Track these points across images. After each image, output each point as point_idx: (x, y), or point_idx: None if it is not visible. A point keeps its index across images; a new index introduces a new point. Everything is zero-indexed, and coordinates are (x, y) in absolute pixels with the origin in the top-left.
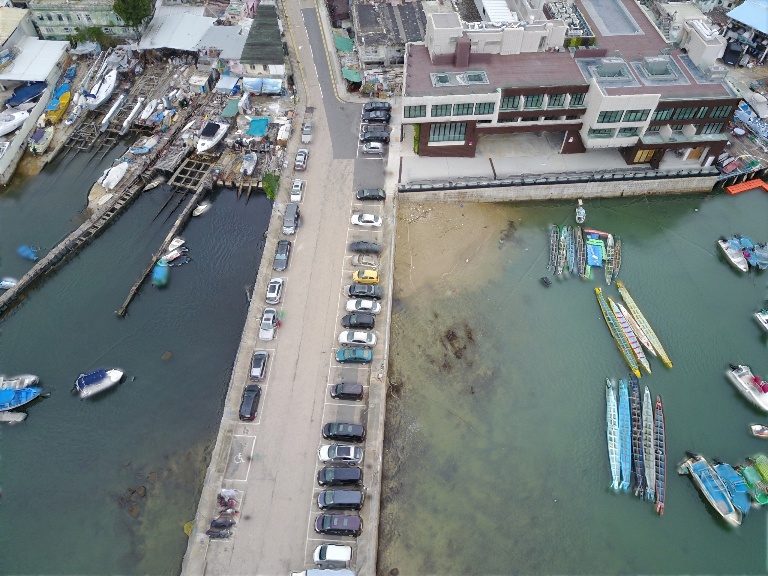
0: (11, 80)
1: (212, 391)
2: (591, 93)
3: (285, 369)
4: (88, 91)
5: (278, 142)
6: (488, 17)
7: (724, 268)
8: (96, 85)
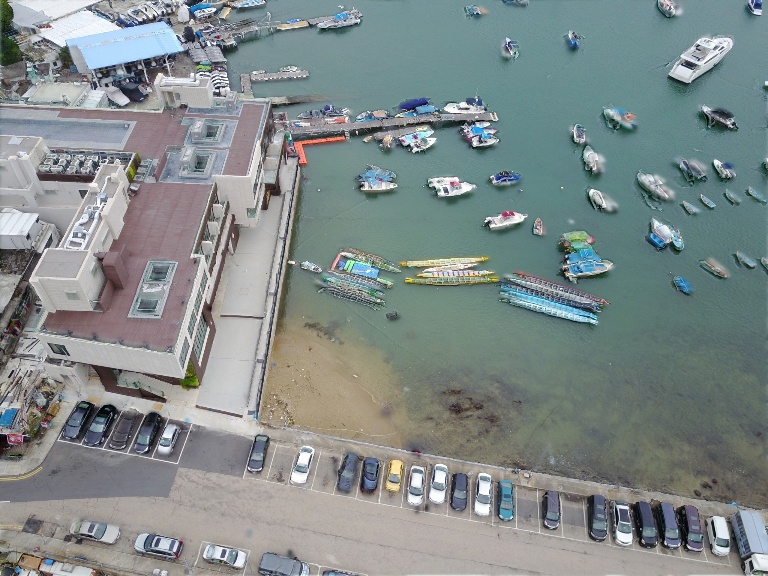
0: None
1: None
2: (225, 187)
3: None
4: None
5: None
6: (2, 236)
7: (387, 198)
8: None
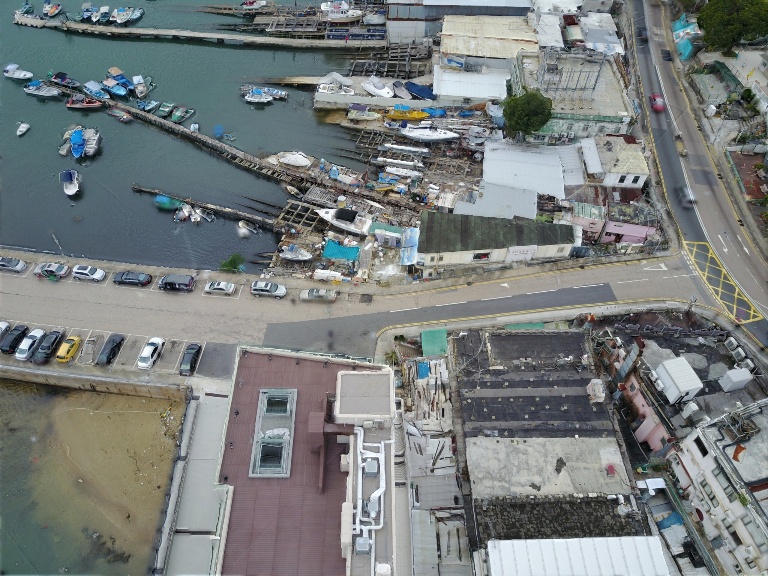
0: None
1: None
2: None
3: None
4: None
5: None
6: None
7: None
8: None
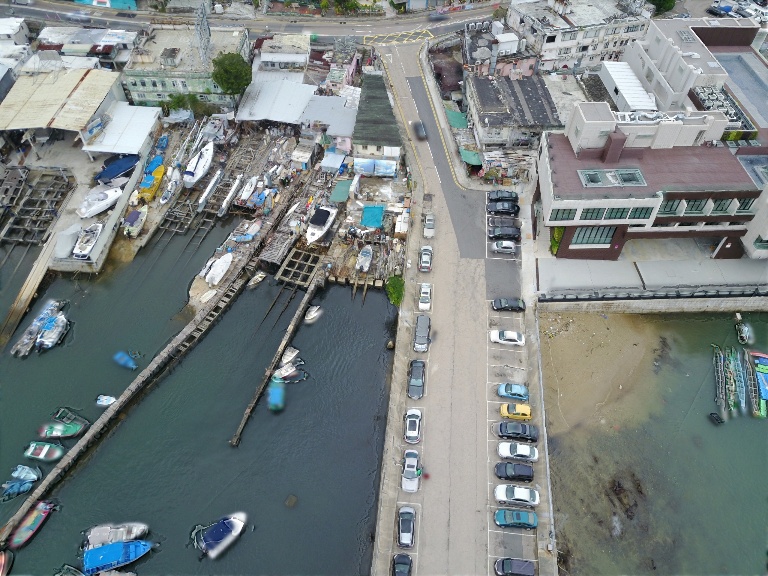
0: (102, 152)
1: (347, 551)
2: (764, 200)
3: (436, 532)
4: (182, 164)
5: (395, 234)
6: (624, 99)
7: None
8: (192, 160)
